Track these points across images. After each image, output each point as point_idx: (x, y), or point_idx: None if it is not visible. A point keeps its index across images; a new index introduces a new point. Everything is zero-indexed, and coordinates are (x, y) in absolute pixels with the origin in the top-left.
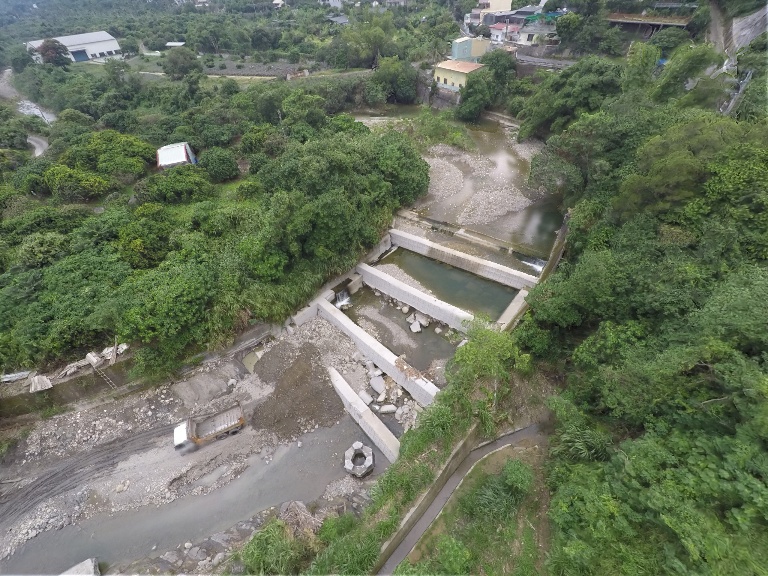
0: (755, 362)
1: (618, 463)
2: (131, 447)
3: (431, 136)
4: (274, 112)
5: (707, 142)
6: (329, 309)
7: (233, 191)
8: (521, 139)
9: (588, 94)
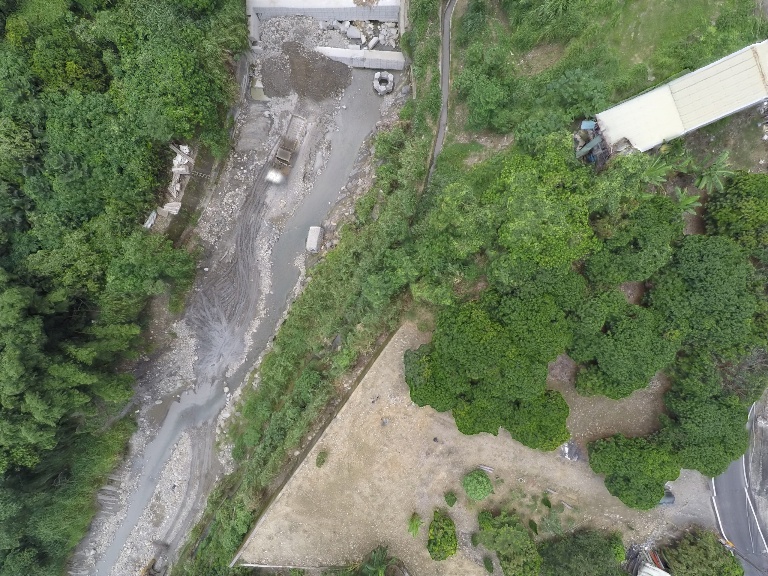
0: None
1: None
2: (260, 192)
3: None
4: None
5: None
6: (267, 4)
7: None
8: None
9: None
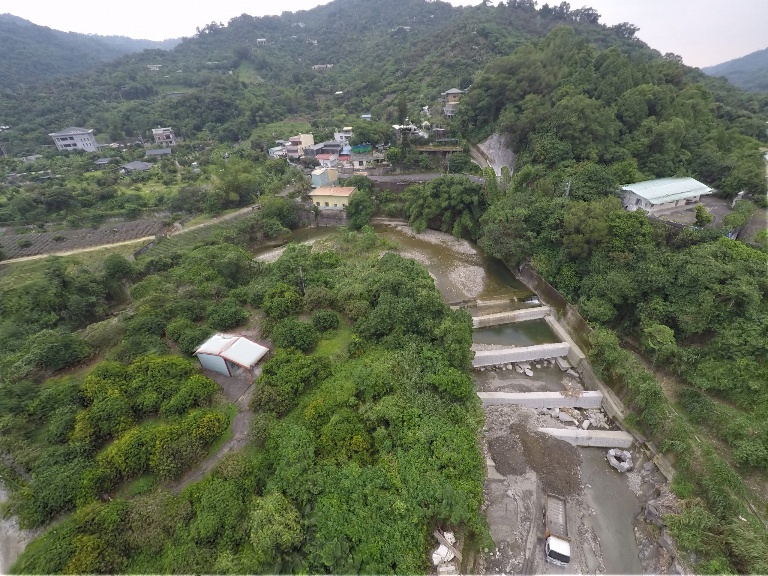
0: (731, 285)
1: (728, 346)
2: None
3: (368, 248)
4: (240, 273)
5: (599, 213)
6: (486, 396)
7: (337, 353)
8: (419, 231)
9: (461, 196)
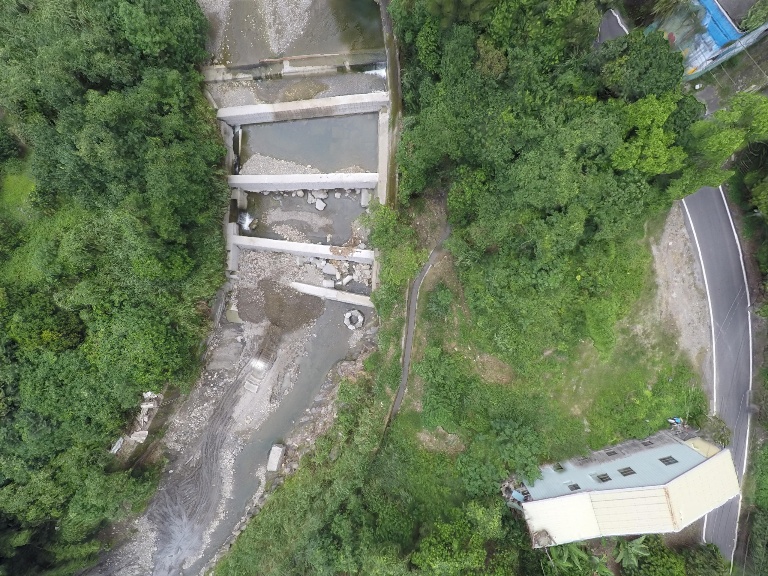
0: (543, 221)
1: None
2: (228, 406)
3: None
4: None
5: None
6: (247, 243)
7: (25, 206)
8: None
9: None
